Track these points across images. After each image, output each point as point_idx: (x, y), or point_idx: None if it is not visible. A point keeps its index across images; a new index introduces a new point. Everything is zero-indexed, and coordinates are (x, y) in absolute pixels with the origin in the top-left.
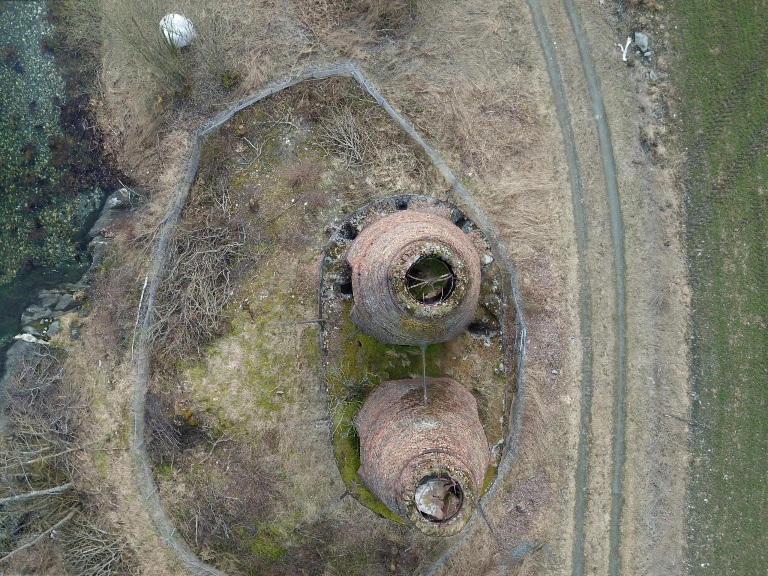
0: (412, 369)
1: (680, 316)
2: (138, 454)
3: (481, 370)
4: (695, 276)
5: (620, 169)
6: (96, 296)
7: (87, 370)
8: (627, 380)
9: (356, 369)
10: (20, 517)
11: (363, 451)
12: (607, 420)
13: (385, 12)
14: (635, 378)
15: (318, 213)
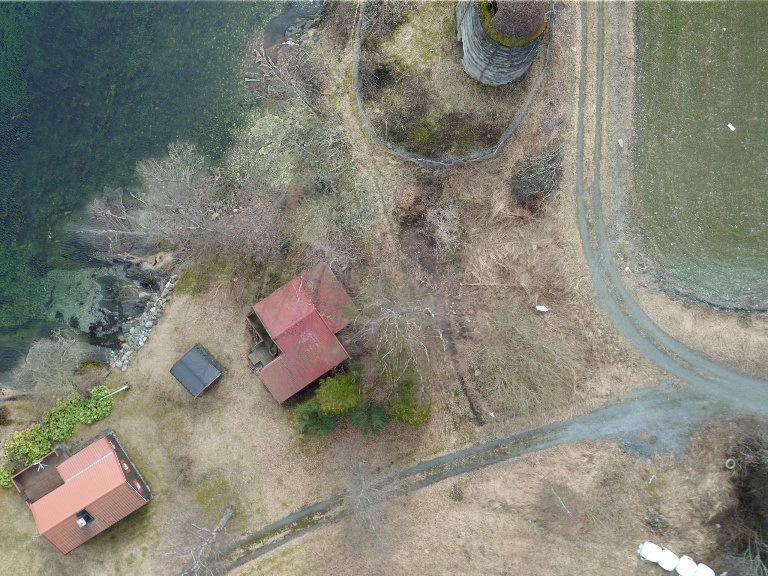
0: None
1: (630, 8)
2: (354, 95)
3: None
4: None
5: None
6: (328, 18)
7: (324, 56)
8: (604, 40)
9: None
10: (285, 140)
11: None
12: (595, 59)
13: None
14: (608, 39)
15: None
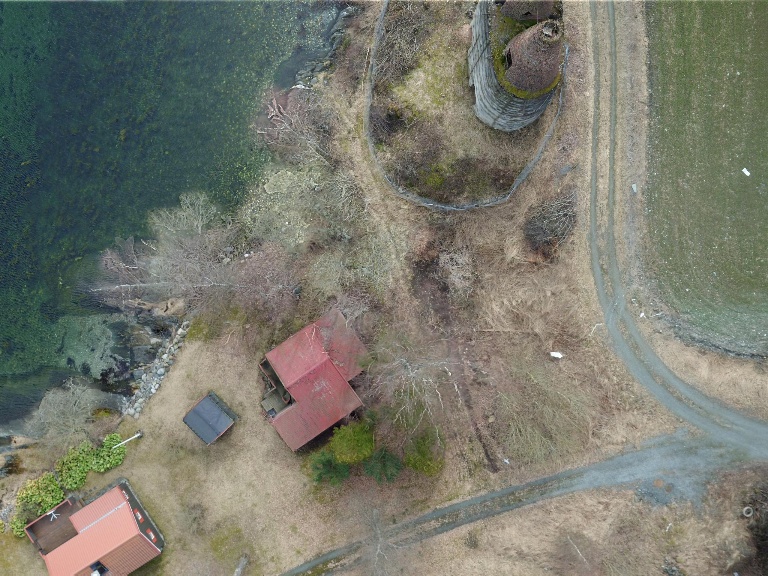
0: None
1: (643, 52)
2: (365, 139)
3: None
4: (650, 32)
5: None
6: (338, 62)
7: (335, 100)
8: (617, 84)
9: (504, 32)
10: None
11: (513, 48)
12: (607, 104)
13: None
14: (621, 83)
15: (462, 5)
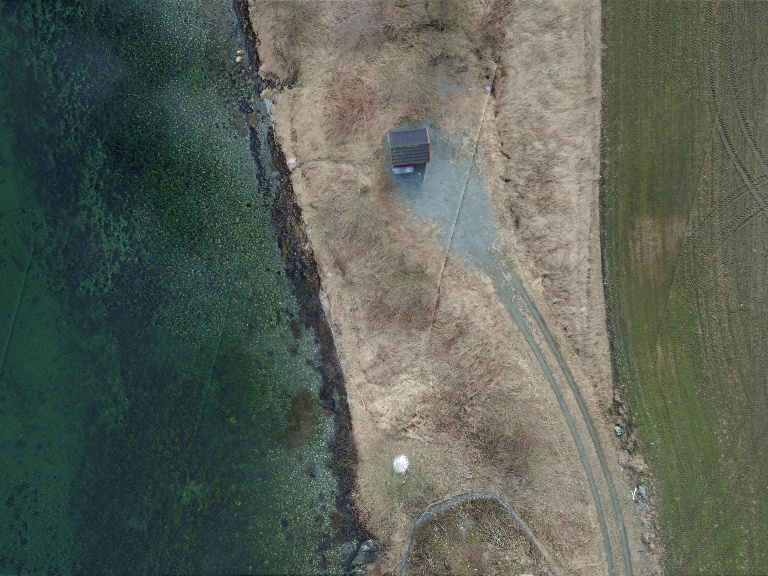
0: None
1: None
2: None
3: None
4: None
5: (632, 555)
6: None
7: None
8: None
9: None
10: None
11: None
12: None
13: (512, 465)
14: None
15: None
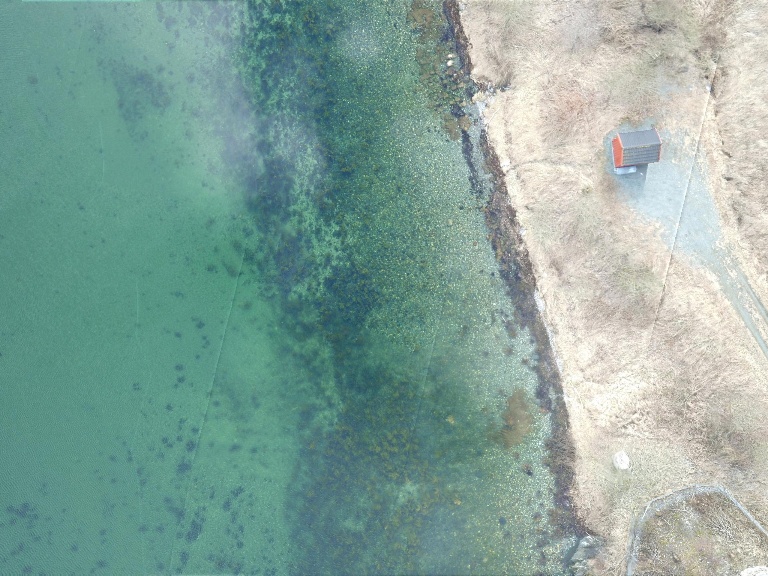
0: None
1: None
2: None
3: None
4: None
5: None
6: None
7: None
8: None
9: None
10: None
11: None
12: None
13: (738, 459)
14: None
15: (717, 569)
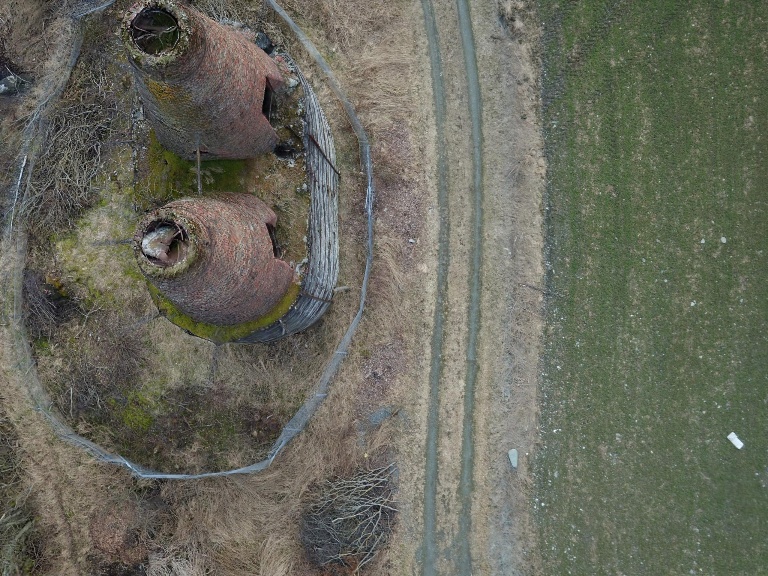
0: (216, 187)
1: (536, 187)
2: (17, 330)
3: (282, 188)
4: (550, 148)
5: (479, 44)
6: None
7: None
8: (483, 250)
9: (162, 186)
10: None
11: None
12: (463, 289)
13: None
14: (491, 248)
15: None
